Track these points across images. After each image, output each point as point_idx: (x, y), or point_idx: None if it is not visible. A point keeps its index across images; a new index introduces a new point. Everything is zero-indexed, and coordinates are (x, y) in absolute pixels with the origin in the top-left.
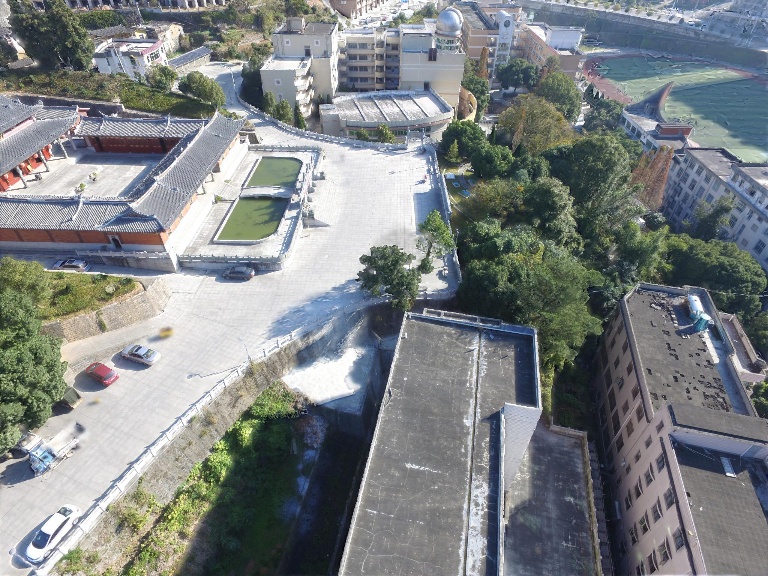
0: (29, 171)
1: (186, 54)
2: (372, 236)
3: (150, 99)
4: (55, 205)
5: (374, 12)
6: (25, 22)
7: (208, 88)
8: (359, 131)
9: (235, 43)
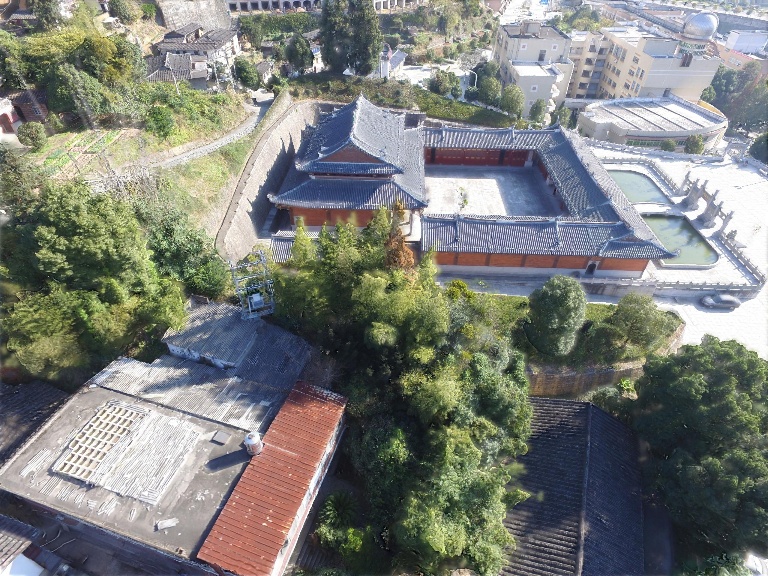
0: None
1: (391, 58)
2: None
3: (449, 107)
4: (528, 227)
5: (508, 14)
6: (337, 26)
7: (516, 96)
8: (669, 142)
9: (424, 46)
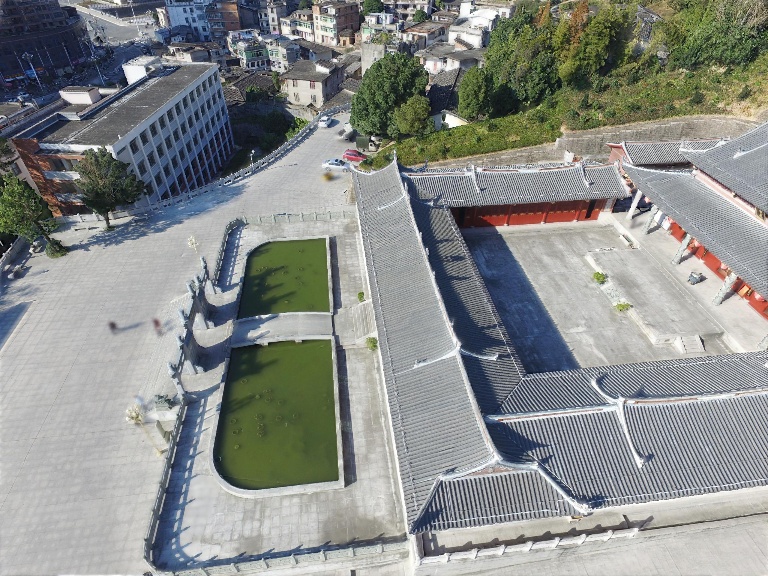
0: (740, 292)
1: None
2: (108, 290)
3: None
4: None
5: None
6: None
7: None
8: None
9: None
